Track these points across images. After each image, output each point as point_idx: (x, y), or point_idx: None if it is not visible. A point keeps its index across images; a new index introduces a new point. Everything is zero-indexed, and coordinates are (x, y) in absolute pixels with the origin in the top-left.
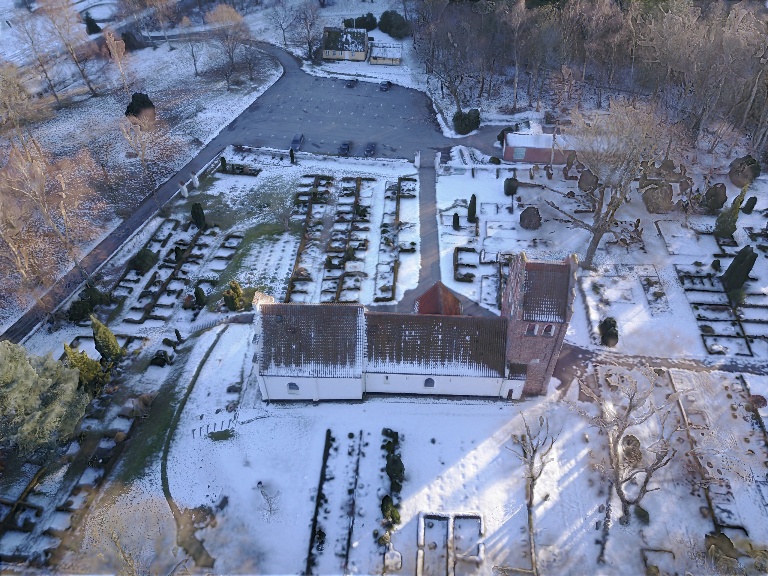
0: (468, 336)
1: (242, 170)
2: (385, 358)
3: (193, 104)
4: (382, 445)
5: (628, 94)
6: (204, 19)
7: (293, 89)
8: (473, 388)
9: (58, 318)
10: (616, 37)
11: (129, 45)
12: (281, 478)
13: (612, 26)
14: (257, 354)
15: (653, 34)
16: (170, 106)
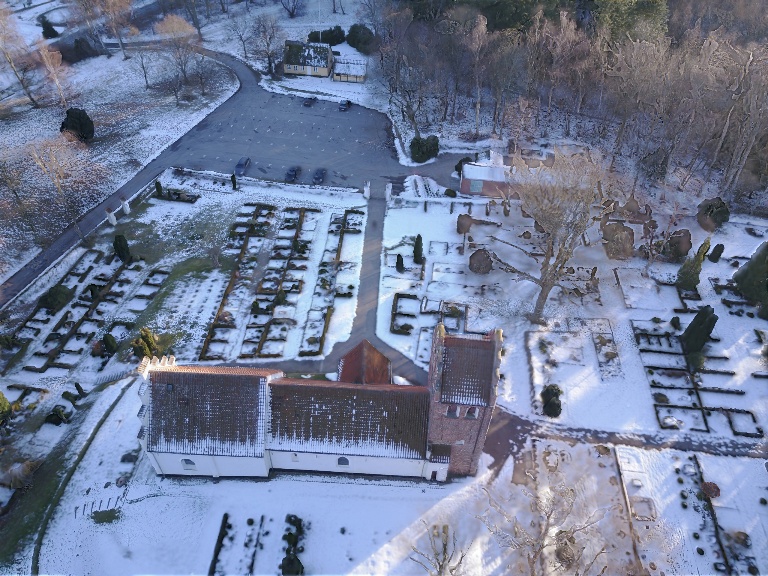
0: (386, 412)
1: (179, 196)
2: (292, 434)
3: (138, 120)
4: (284, 535)
5: (600, 121)
6: (154, 29)
7: (247, 106)
8: (392, 468)
9: None
10: (583, 64)
11: (82, 52)
12: (164, 574)
13: (579, 53)
14: (144, 428)
15: (620, 64)
16: (113, 121)
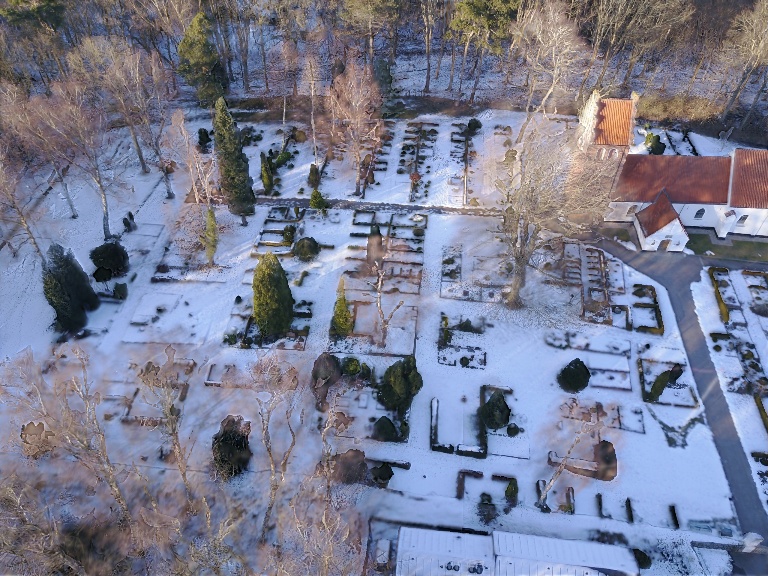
0: None
1: None
2: None
3: None
4: None
5: None
6: None
7: None
8: None
9: None
10: None
11: None
12: None
13: None
14: None
15: None
16: None
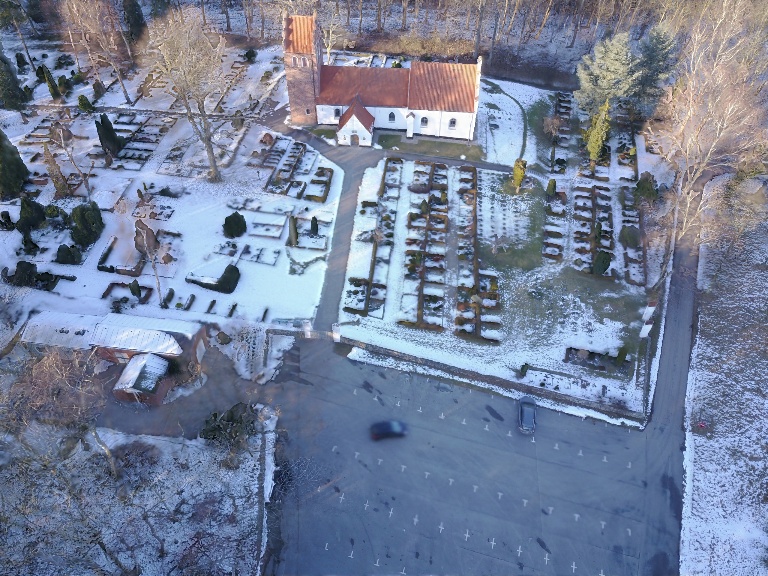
0: None
1: None
2: None
3: None
4: None
5: None
6: None
7: None
8: None
9: (667, 193)
10: None
11: None
12: None
13: None
14: None
15: None
16: None
